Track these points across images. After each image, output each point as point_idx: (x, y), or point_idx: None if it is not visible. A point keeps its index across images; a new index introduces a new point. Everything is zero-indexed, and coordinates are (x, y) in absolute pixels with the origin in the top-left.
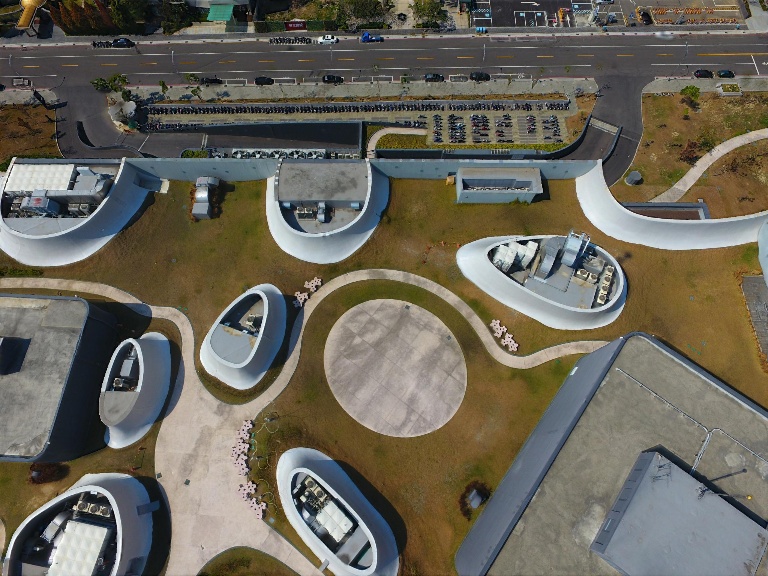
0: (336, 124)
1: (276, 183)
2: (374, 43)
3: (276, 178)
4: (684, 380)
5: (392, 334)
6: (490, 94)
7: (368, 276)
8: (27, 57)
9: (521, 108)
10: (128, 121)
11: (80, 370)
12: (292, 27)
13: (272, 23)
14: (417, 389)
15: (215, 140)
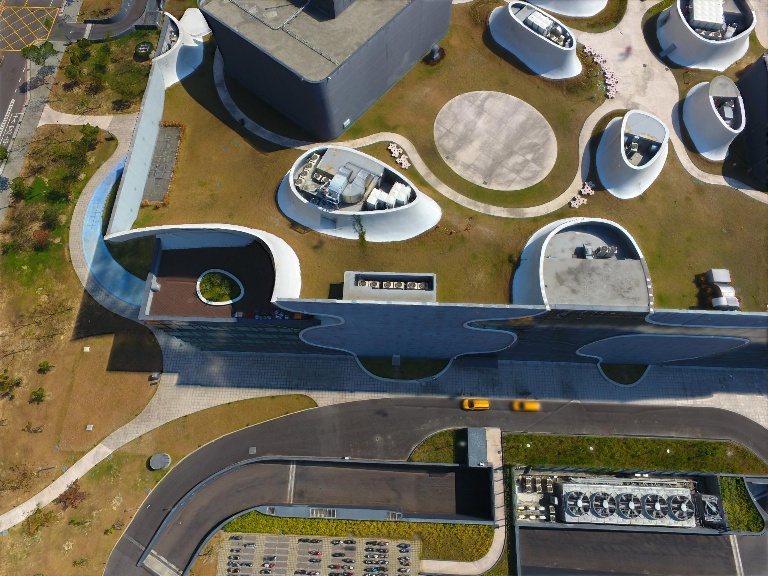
0: None
1: (649, 280)
2: None
3: (651, 286)
4: (287, 57)
5: (499, 161)
6: None
7: (525, 211)
8: None
9: None
10: None
11: (767, 111)
12: None
13: None
14: (476, 121)
15: (725, 569)
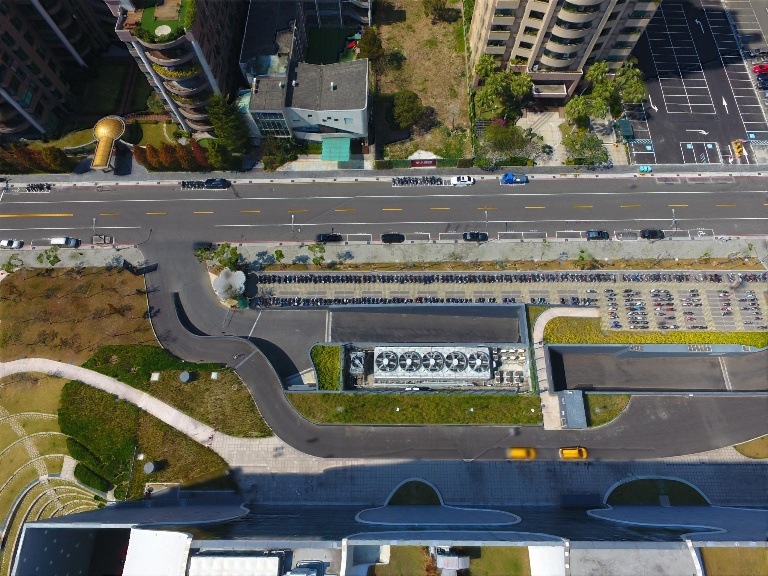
0: (493, 306)
1: None
2: (518, 185)
3: None
4: None
5: None
6: (668, 258)
7: None
8: (104, 201)
9: (710, 280)
10: (238, 299)
11: None
12: (419, 164)
13: (397, 161)
14: None
15: (341, 319)
